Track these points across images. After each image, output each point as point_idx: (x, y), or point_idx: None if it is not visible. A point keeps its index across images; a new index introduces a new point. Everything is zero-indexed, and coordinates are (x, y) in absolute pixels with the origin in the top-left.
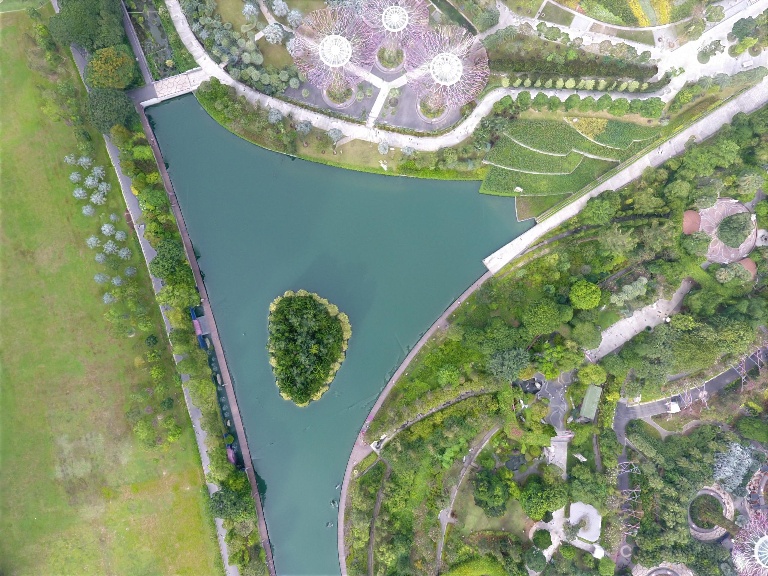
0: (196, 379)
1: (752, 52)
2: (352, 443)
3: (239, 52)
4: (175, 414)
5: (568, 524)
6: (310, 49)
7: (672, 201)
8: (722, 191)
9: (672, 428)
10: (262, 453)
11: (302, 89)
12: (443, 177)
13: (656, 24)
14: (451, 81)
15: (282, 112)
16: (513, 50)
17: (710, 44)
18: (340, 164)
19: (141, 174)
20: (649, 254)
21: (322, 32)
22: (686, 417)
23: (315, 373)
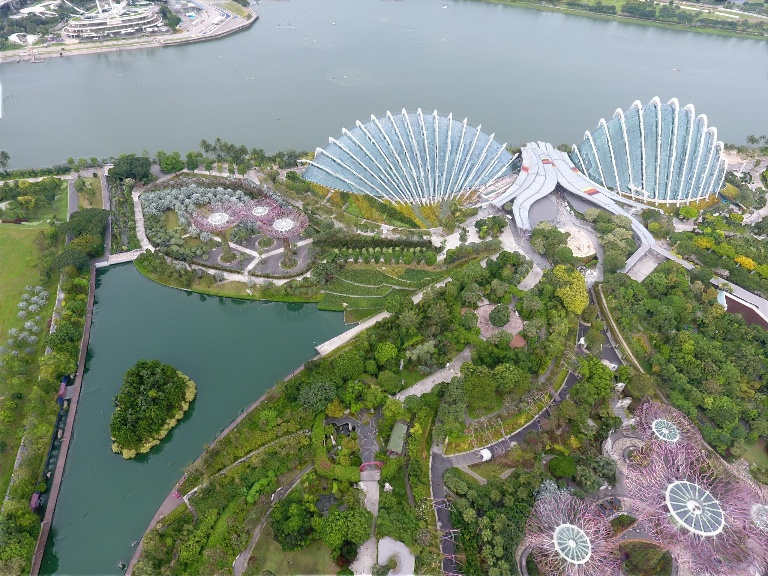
0: (38, 420)
1: (493, 237)
2: (165, 496)
3: (169, 238)
4: (1, 463)
5: (375, 564)
6: (204, 218)
7: None
8: (489, 299)
9: (490, 476)
10: (71, 529)
11: (203, 255)
12: (292, 300)
13: (431, 227)
14: (285, 229)
15: (188, 268)
16: (340, 236)
17: None
18: (219, 293)
19: (74, 294)
20: (435, 328)
21: (214, 212)
22: (502, 465)
23: (147, 412)
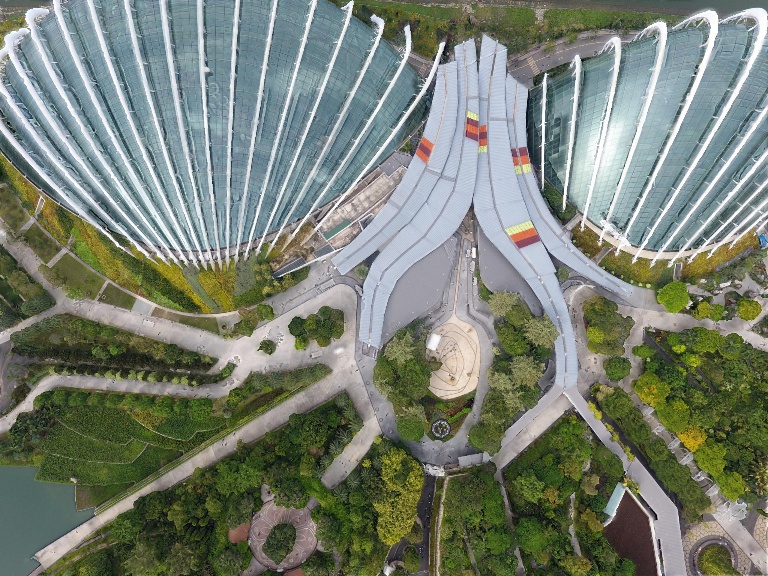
0: None
1: None
2: None
3: None
4: None
5: None
6: None
7: (207, 515)
8: None
9: None
10: None
11: None
12: None
13: (220, 311)
14: None
15: None
16: (56, 342)
17: (262, 343)
18: None
19: None
20: None
21: None
22: None
23: None
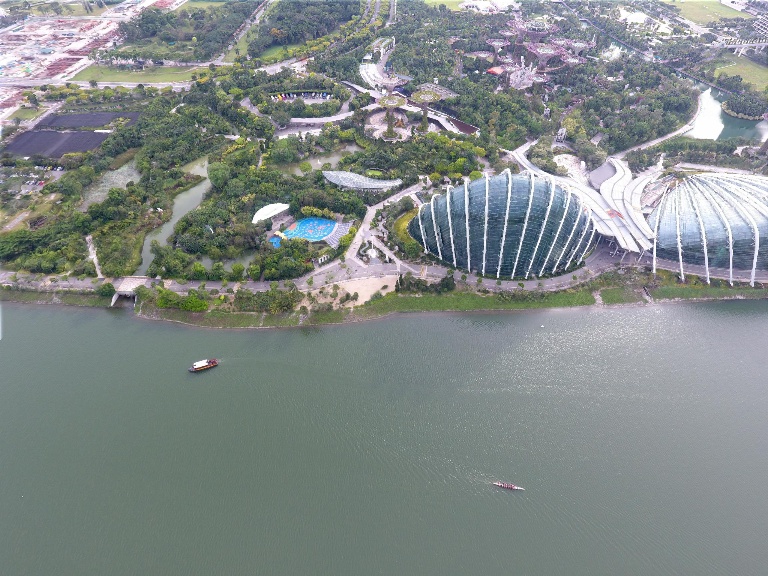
0: None
1: None
2: None
3: None
4: None
5: None
6: None
7: None
8: None
9: None
10: None
11: None
12: None
13: None
14: None
15: None
16: None
17: None
18: None
19: None
20: None
21: None
22: None
23: None
